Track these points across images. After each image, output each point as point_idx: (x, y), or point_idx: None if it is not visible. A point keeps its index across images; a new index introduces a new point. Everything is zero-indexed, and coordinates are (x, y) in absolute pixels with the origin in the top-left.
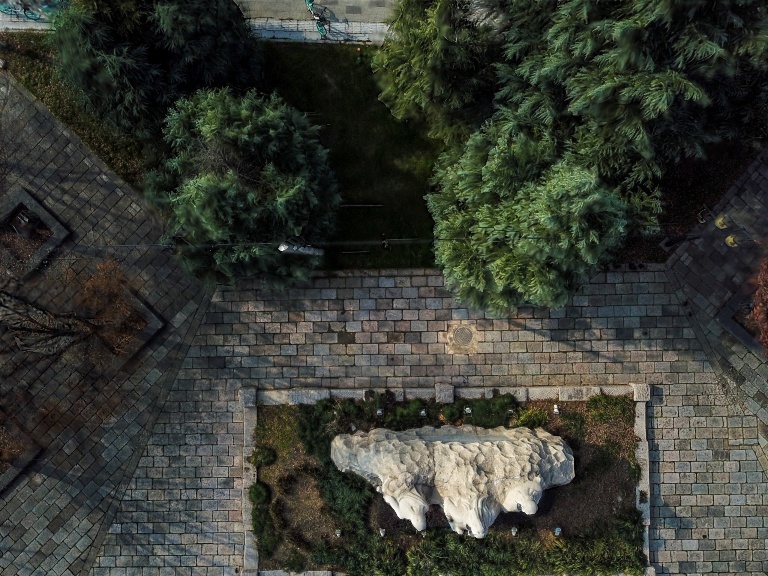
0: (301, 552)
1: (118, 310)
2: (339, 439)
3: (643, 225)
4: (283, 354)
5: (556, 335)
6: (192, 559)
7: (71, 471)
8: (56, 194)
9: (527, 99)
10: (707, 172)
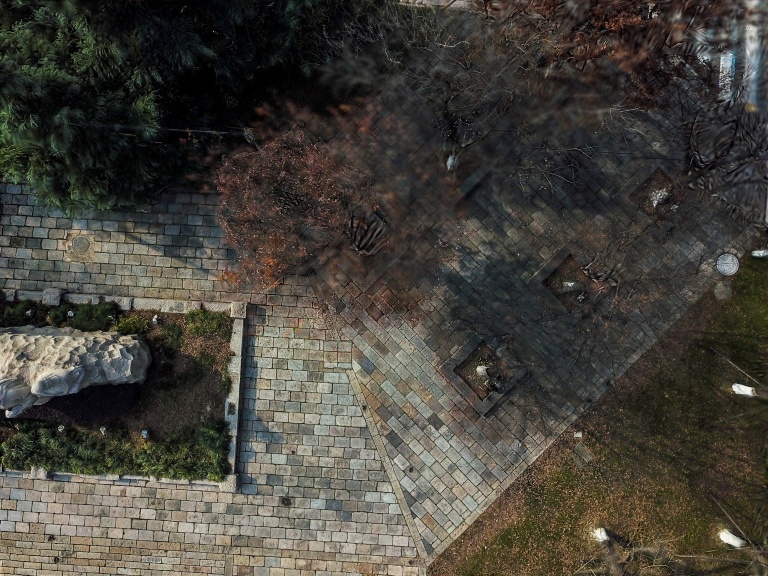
0: None
1: None
2: None
3: (144, 126)
4: None
5: (169, 251)
6: None
7: None
8: None
9: None
10: (328, 107)
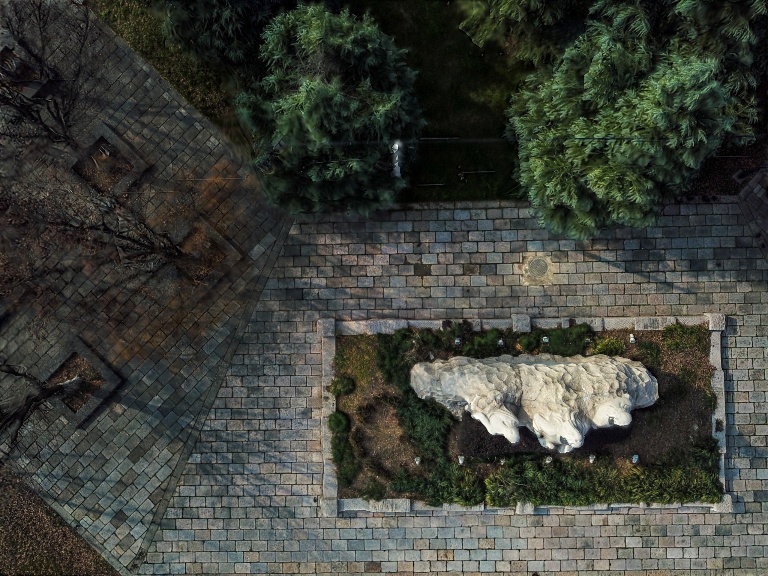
0: (380, 480)
1: (197, 242)
2: (419, 367)
3: (738, 136)
4: (360, 286)
5: (630, 266)
6: (271, 488)
7: (151, 402)
8: (136, 128)
9: (623, 13)
10: None
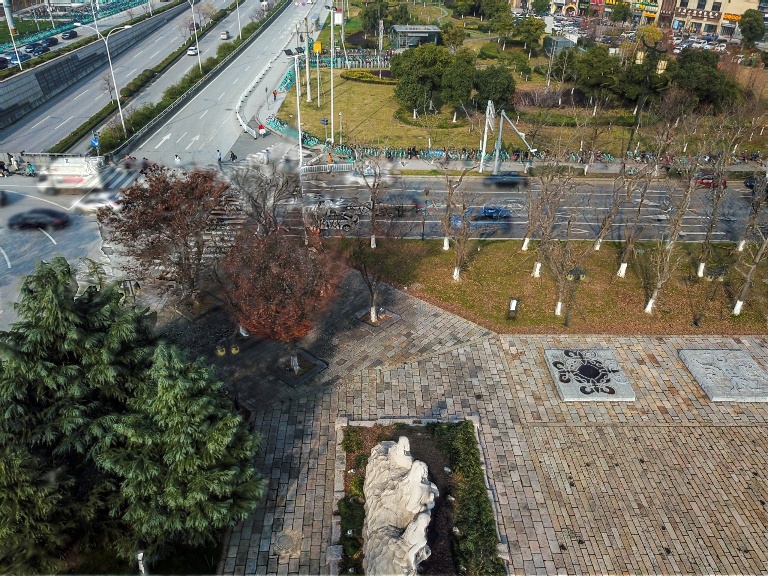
0: None
1: None
2: None
3: None
4: None
5: (294, 475)
6: None
7: None
8: None
9: (92, 430)
10: None
